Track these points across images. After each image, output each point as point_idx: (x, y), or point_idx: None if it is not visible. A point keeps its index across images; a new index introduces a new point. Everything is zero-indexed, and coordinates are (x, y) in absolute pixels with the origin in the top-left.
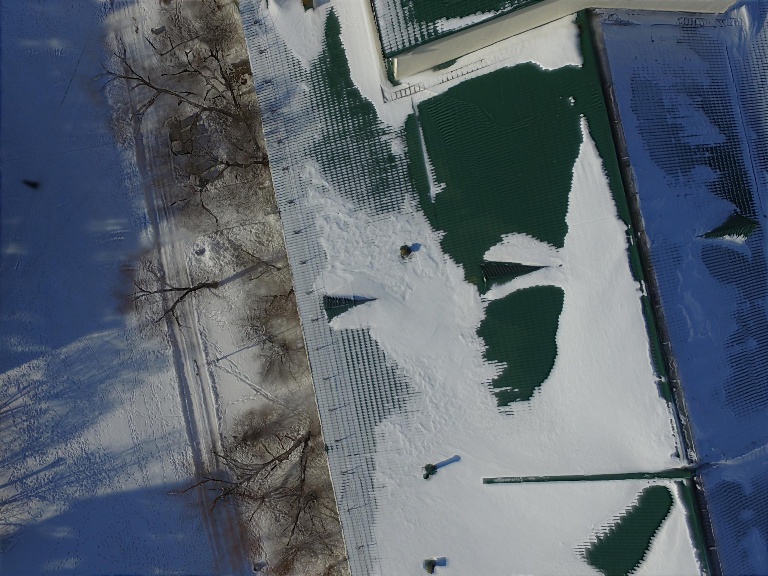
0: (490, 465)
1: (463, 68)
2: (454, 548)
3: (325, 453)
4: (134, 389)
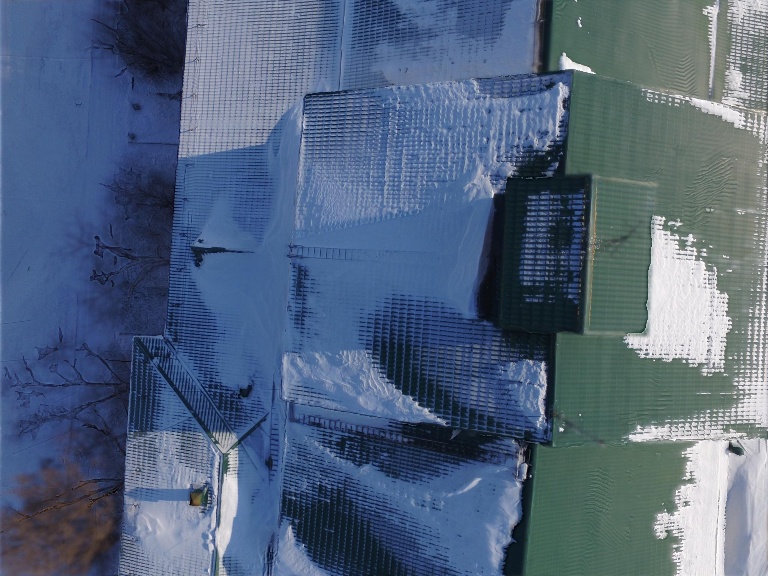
0: None
1: None
2: None
3: None
4: None
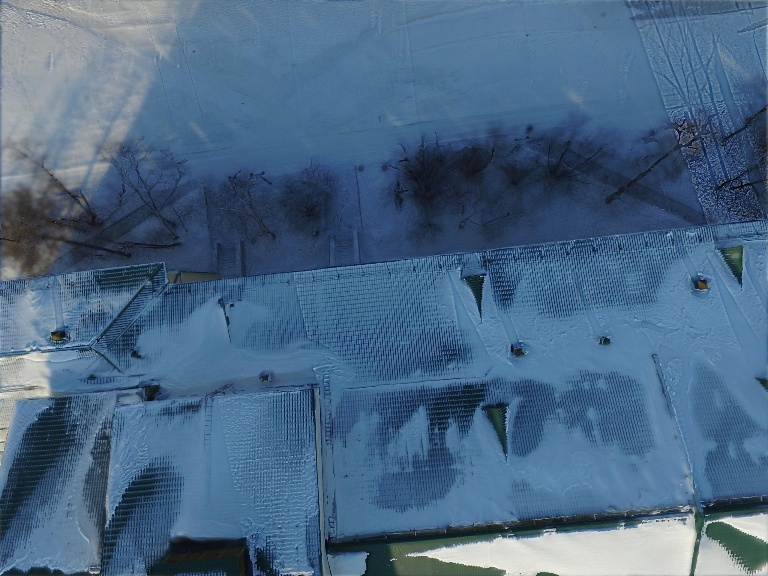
0: None
1: None
2: None
3: None
4: None
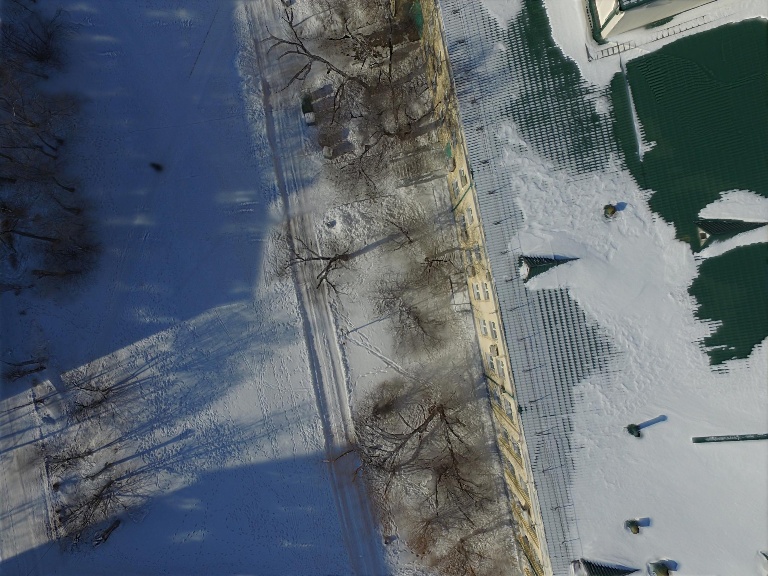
0: (701, 424)
1: (681, 25)
2: (659, 508)
3: (518, 414)
4: (263, 361)
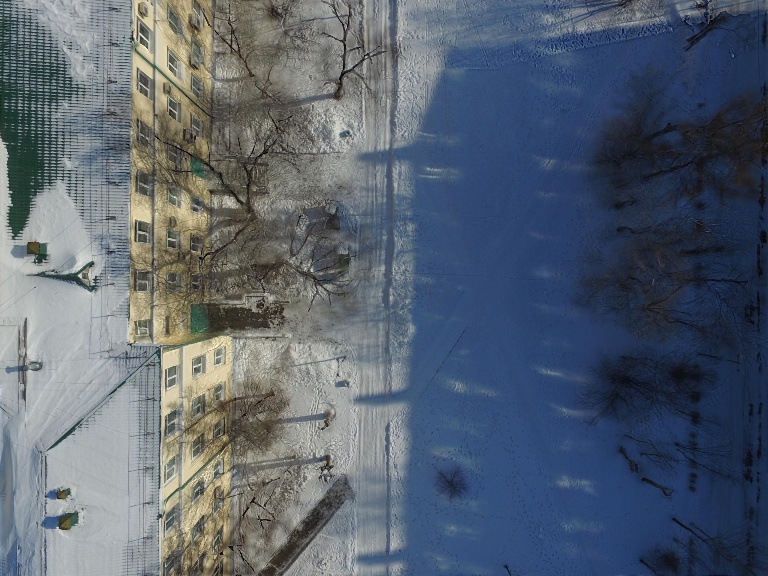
0: None
1: None
2: None
3: None
4: (447, 2)
